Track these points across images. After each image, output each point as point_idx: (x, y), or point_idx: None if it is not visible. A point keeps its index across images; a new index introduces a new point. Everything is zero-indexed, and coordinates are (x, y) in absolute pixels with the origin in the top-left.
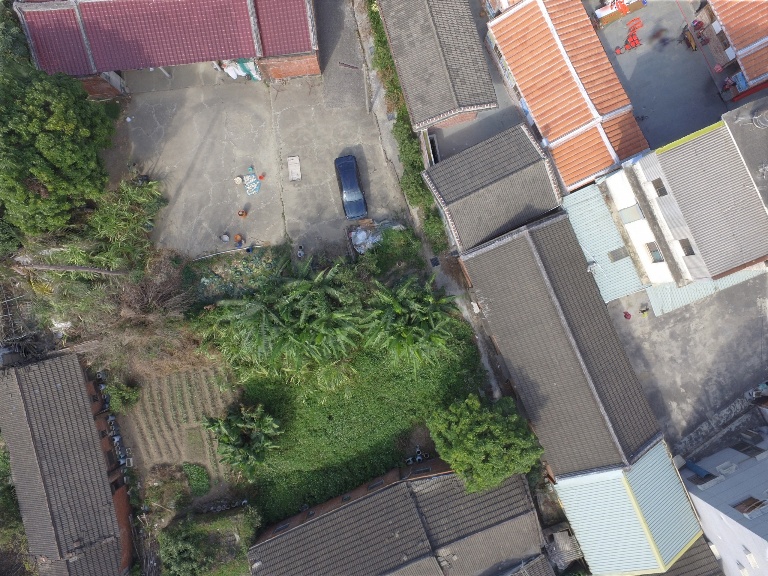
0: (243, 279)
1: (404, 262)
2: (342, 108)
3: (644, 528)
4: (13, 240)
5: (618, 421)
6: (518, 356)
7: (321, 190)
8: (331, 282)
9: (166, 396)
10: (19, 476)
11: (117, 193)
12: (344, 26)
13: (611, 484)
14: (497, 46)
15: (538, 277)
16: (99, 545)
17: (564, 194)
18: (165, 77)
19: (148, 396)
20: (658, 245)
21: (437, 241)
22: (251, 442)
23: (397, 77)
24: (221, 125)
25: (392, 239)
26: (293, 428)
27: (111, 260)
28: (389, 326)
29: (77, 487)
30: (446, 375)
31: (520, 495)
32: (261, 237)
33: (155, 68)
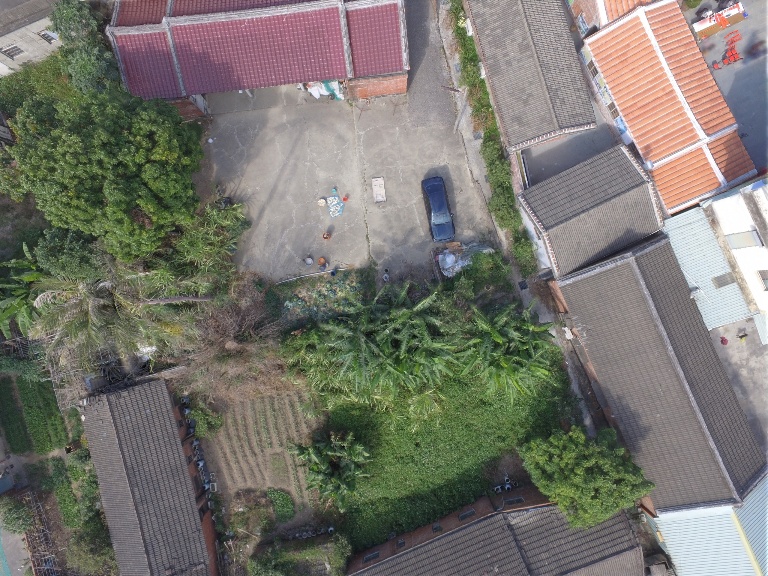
0: (327, 303)
1: (492, 286)
2: (427, 127)
3: (755, 566)
4: (104, 266)
5: (726, 454)
6: (618, 385)
7: (406, 212)
8: (429, 310)
9: (250, 421)
10: (110, 502)
11: (200, 216)
12: (429, 43)
13: (719, 520)
14: (594, 64)
15: (643, 305)
16: (189, 572)
17: (665, 217)
18: (247, 97)
19: (232, 421)
20: None
21: (527, 264)
22: (341, 470)
23: (484, 95)
24: (304, 146)
25: (481, 262)
26: (379, 455)
27: (199, 285)
28: (489, 356)
29: (167, 514)
30: (536, 402)
31: (624, 530)
32: (345, 260)
33: (243, 90)
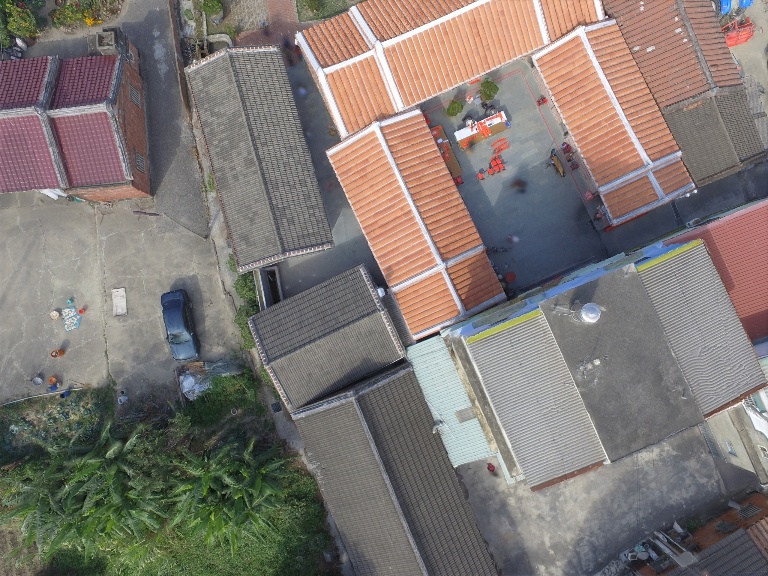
0: (58, 427)
1: (240, 409)
2: (176, 234)
3: None
4: None
5: None
6: (353, 531)
7: (149, 326)
8: (129, 455)
9: None
10: None
11: None
12: (180, 143)
13: None
14: (337, 177)
15: (369, 448)
16: None
17: (409, 343)
18: None
19: None
20: None
21: None
22: None
23: None
24: (38, 251)
25: (224, 386)
26: None
27: None
28: (194, 508)
29: None
30: (285, 539)
31: None
32: (80, 378)
33: None
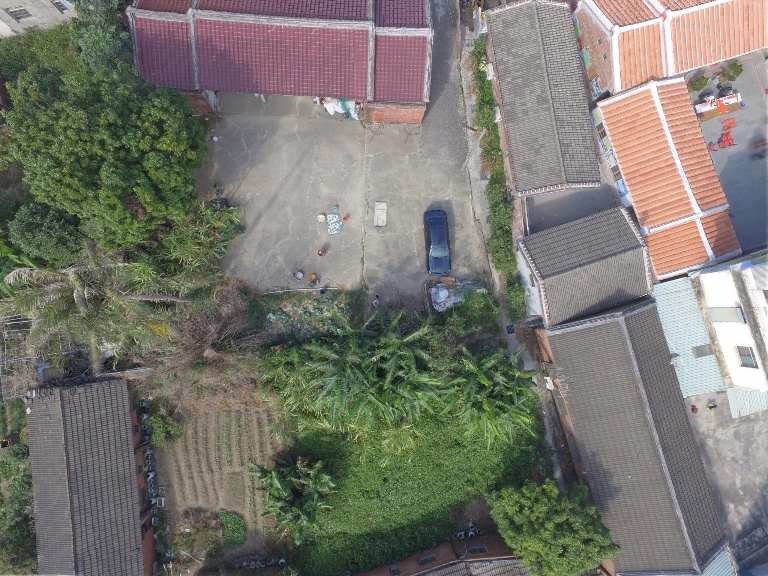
0: (311, 320)
1: (481, 326)
2: (437, 161)
3: None
4: (82, 251)
5: (690, 524)
6: (593, 442)
7: (405, 240)
8: (418, 343)
9: (212, 434)
10: (42, 508)
11: None
12: (449, 80)
13: None
14: (604, 126)
15: (627, 365)
16: None
17: (654, 282)
18: (260, 102)
19: (192, 432)
20: (758, 353)
21: (517, 309)
22: (303, 499)
23: (495, 138)
24: (311, 159)
25: (473, 301)
26: (344, 486)
27: (181, 285)
28: (473, 397)
29: (106, 528)
30: (510, 449)
31: None
32: (336, 279)
33: (259, 94)
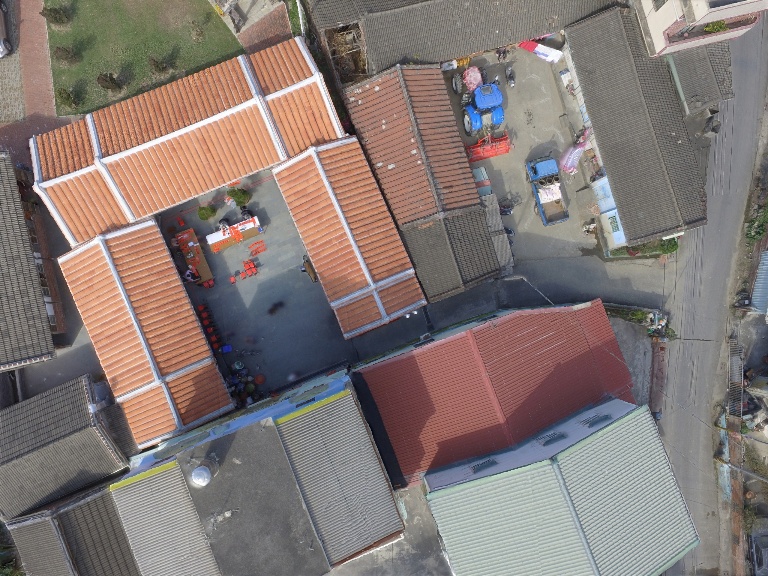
0: None
1: None
2: None
3: None
4: None
5: None
6: None
7: None
8: None
9: None
10: None
11: None
12: None
13: None
14: (67, 284)
15: None
16: None
17: (134, 452)
18: None
19: None
20: None
21: None
22: None
23: None
24: None
25: None
26: None
27: None
28: None
29: None
30: None
31: None
32: None
33: None
